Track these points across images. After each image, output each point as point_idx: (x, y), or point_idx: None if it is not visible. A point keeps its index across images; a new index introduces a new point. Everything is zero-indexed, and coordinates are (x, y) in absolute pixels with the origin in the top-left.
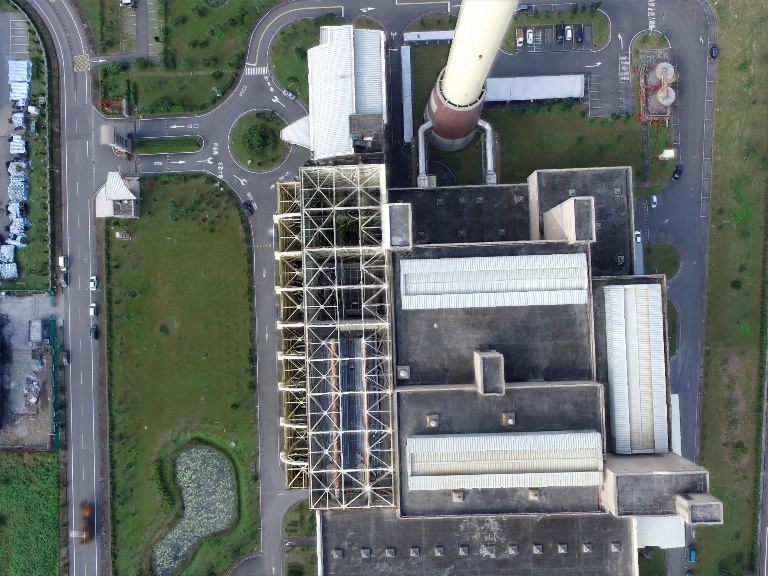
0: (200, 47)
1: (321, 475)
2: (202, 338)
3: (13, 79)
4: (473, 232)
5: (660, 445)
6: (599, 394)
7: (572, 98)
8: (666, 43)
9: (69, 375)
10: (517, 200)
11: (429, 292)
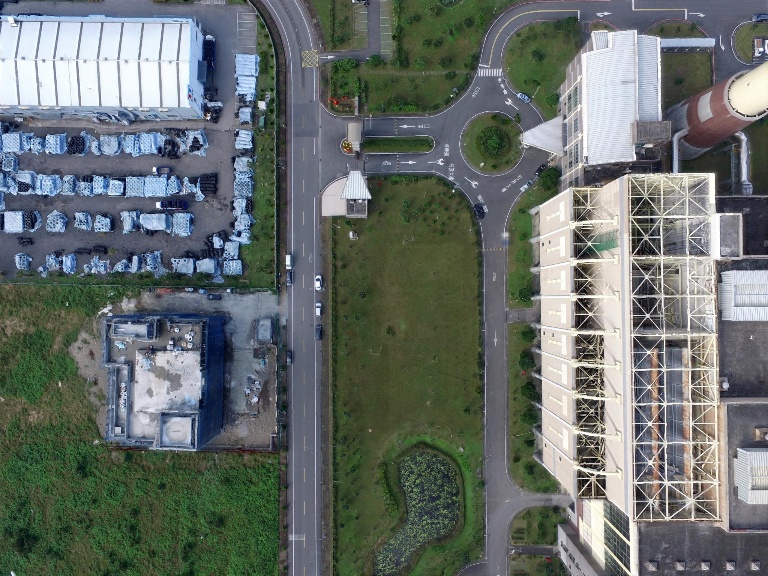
0: (435, 47)
1: (644, 486)
2: (429, 341)
3: (240, 73)
4: None
5: None
6: None
7: None
8: None
9: (291, 375)
10: None
11: (757, 304)
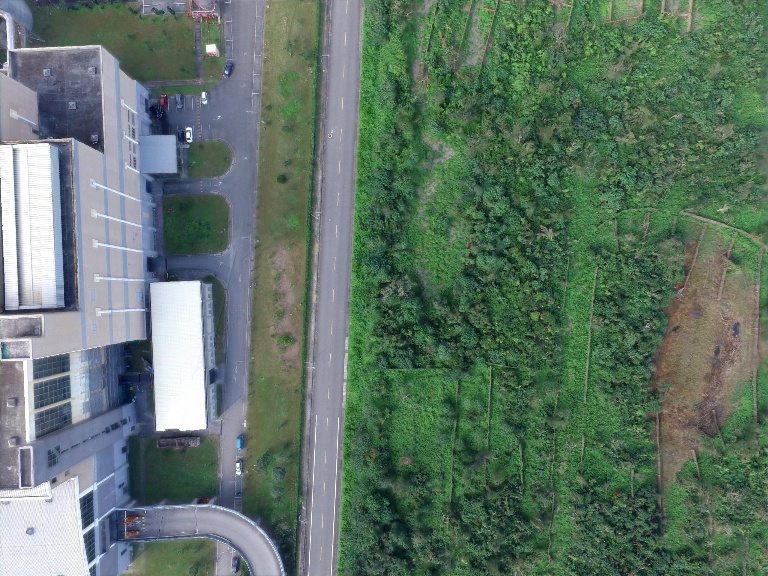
0: None
1: None
2: None
3: None
4: None
5: (47, 301)
6: None
7: None
8: None
9: None
10: None
11: None
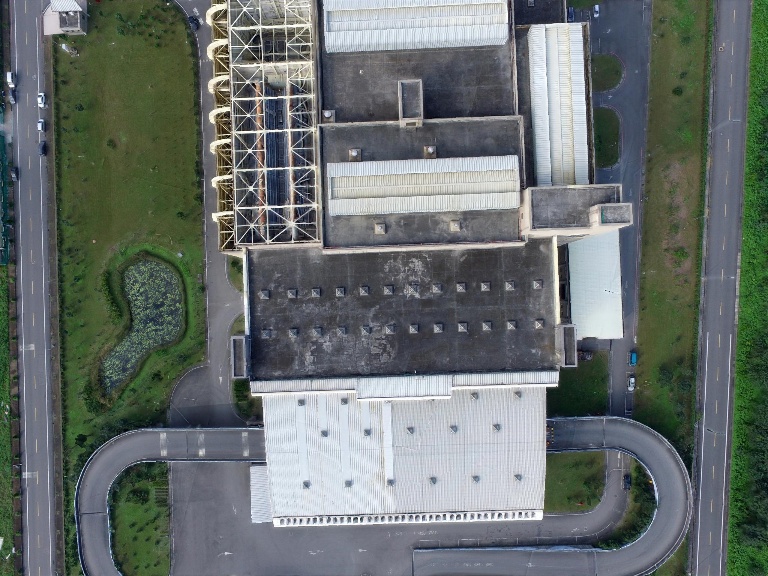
0: None
1: (246, 212)
2: (149, 152)
3: None
4: None
5: (580, 180)
6: (519, 128)
7: None
8: None
9: (18, 191)
10: None
11: (352, 30)
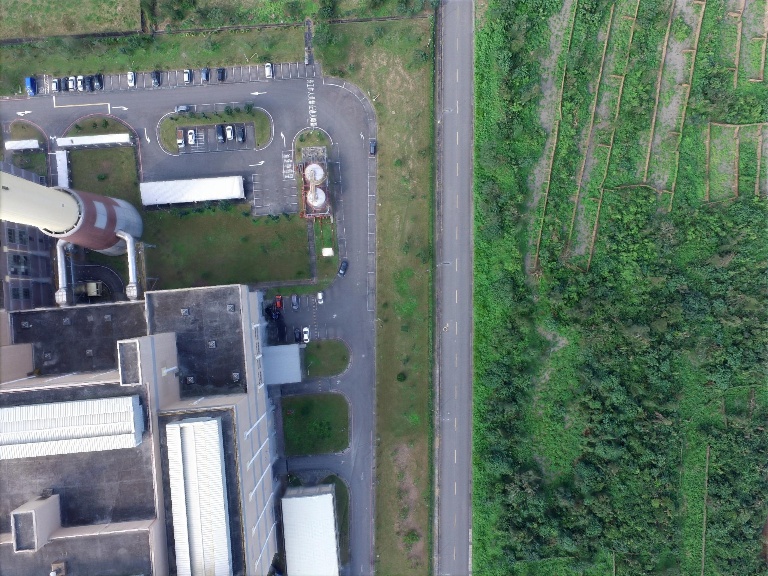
0: None
1: None
2: None
3: None
4: (103, 350)
5: None
6: None
7: (228, 201)
8: (328, 140)
9: None
10: None
11: None
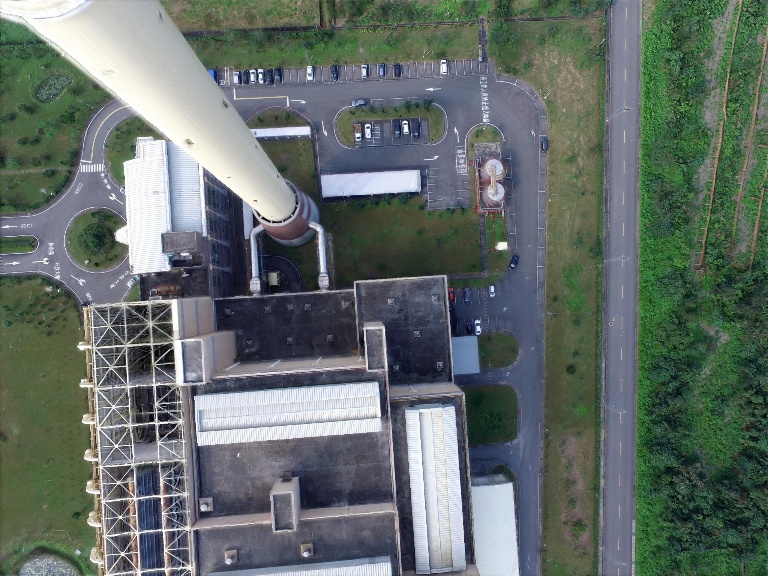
0: (30, 145)
1: None
2: (43, 444)
3: None
4: (302, 338)
5: (457, 563)
6: None
7: (408, 194)
8: (500, 136)
9: None
10: (344, 305)
11: (225, 426)
